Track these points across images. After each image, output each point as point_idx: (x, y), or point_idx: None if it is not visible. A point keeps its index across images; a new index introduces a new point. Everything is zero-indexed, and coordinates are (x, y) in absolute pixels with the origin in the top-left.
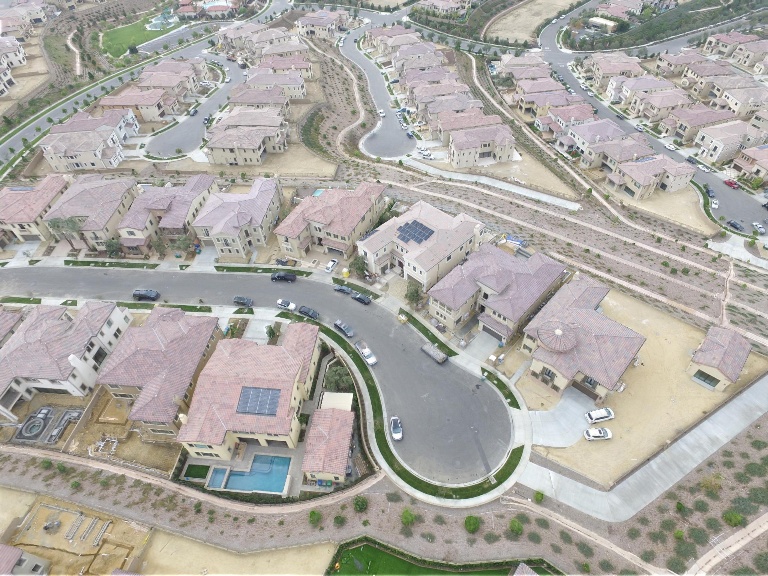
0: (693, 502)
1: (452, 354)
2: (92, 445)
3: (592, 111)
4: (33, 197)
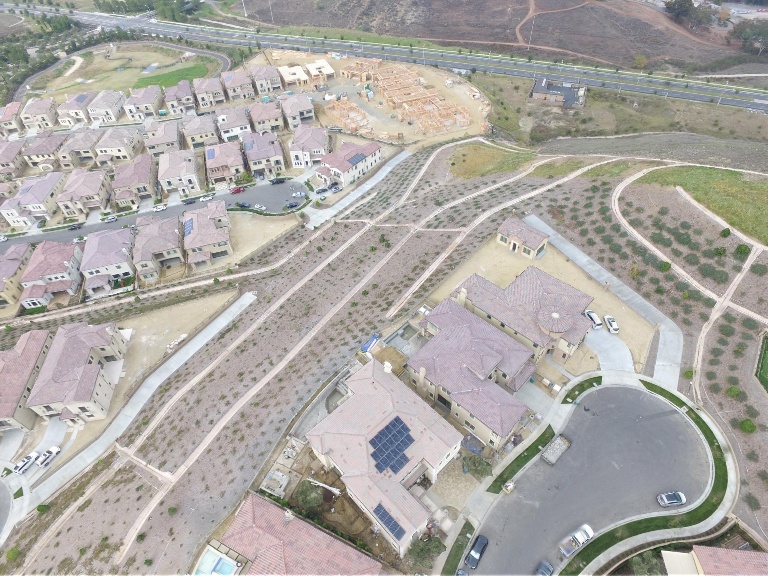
0: (652, 284)
1: (551, 431)
2: None
3: (60, 243)
4: None
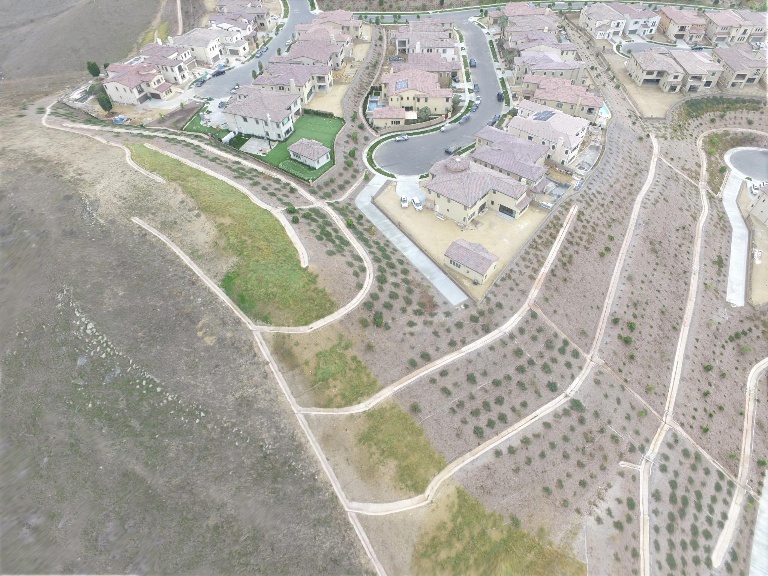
0: (363, 223)
1: None
2: (388, 72)
3: None
4: (524, 9)
